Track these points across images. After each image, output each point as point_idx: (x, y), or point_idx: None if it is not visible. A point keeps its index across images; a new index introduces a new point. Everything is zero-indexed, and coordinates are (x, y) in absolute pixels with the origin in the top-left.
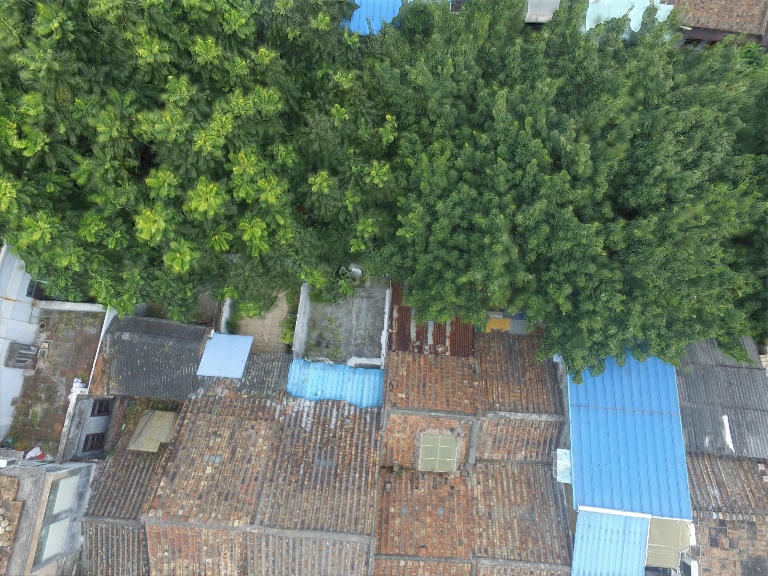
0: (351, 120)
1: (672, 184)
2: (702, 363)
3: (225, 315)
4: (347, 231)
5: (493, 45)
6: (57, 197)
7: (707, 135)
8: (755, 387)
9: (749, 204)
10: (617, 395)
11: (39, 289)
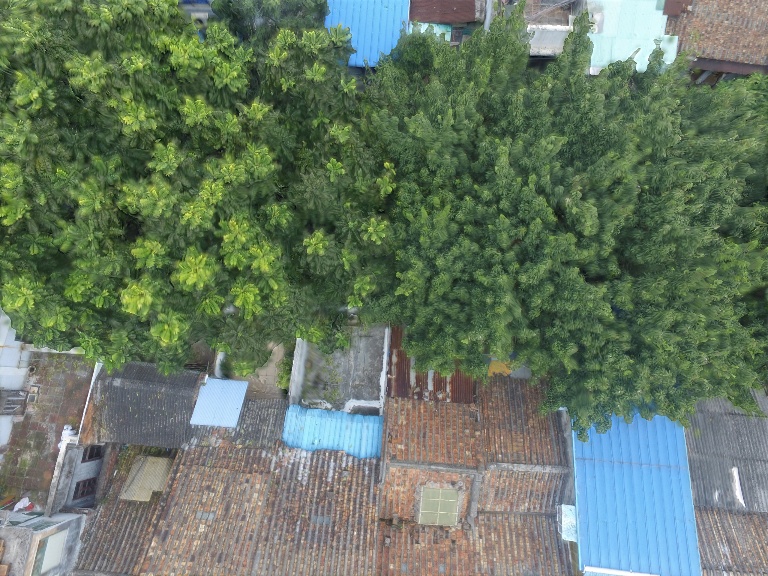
0: (348, 172)
1: (682, 242)
2: (710, 411)
3: (220, 357)
4: None
5: (494, 89)
6: (41, 258)
7: (717, 186)
8: (765, 437)
9: (762, 263)
10: (623, 447)
11: None
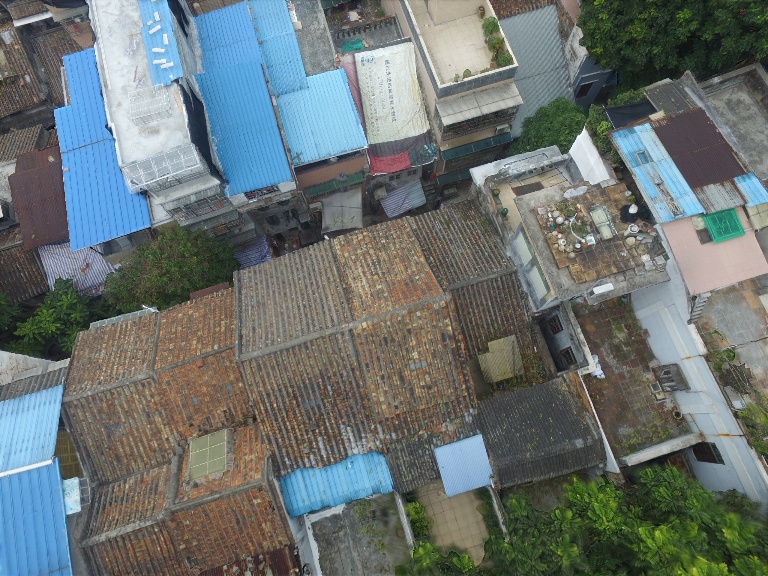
0: None
1: None
2: None
3: (496, 506)
4: None
5: None
6: None
7: None
8: None
9: None
10: None
11: (710, 454)
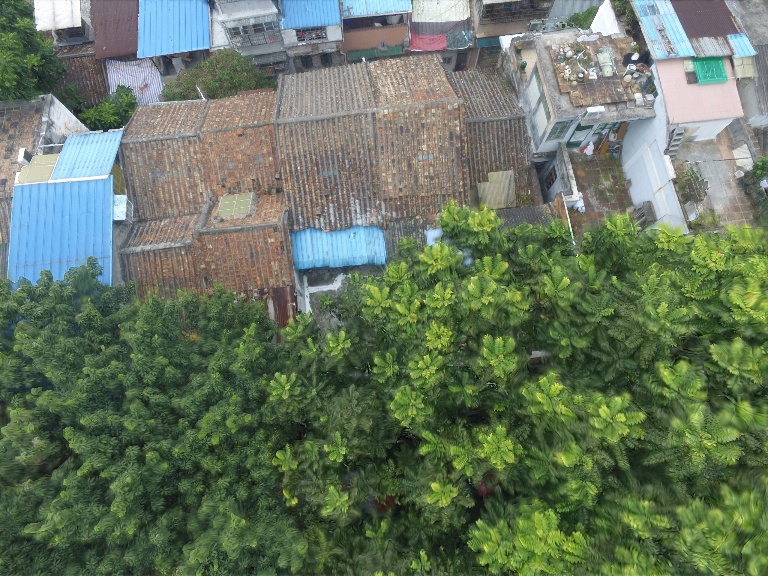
0: None
1: None
2: None
3: None
4: None
5: None
6: None
7: None
8: None
9: None
10: None
11: None
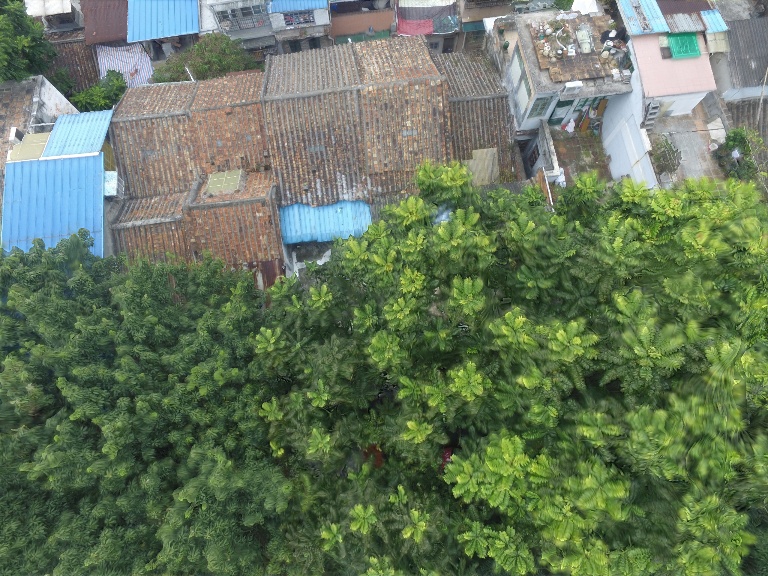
0: None
1: None
2: None
3: None
4: None
5: None
6: None
7: None
8: None
9: None
10: None
11: None
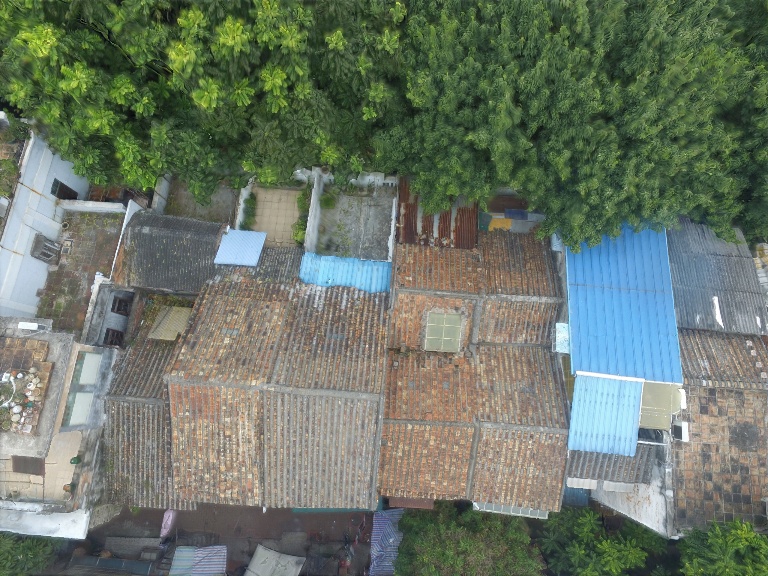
0: None
1: (664, 48)
2: (694, 252)
3: (239, 218)
4: (359, 112)
5: None
6: (91, 57)
7: (698, 14)
8: (744, 273)
9: (736, 66)
10: (613, 276)
11: (62, 190)
